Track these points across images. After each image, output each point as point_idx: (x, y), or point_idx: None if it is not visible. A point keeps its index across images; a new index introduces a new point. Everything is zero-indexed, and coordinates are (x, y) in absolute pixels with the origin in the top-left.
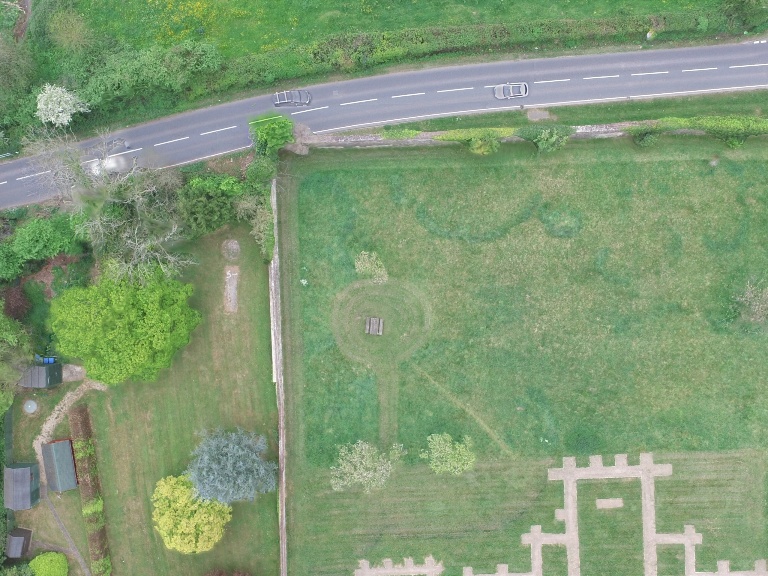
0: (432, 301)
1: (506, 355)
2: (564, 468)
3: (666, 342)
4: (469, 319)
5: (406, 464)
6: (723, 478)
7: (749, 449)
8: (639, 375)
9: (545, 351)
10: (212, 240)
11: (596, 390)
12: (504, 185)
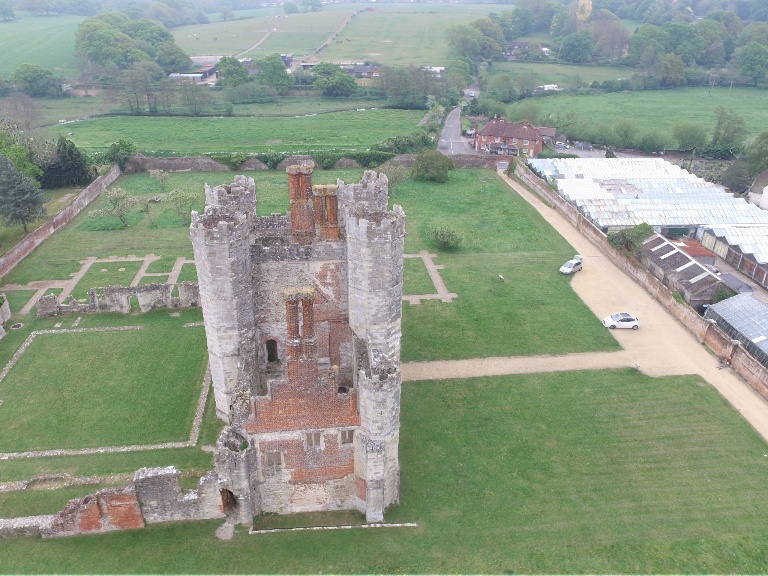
0: None
1: None
2: None
3: None
4: None
5: None
6: None
7: None
8: None
9: None
10: (66, 189)
11: None
12: None
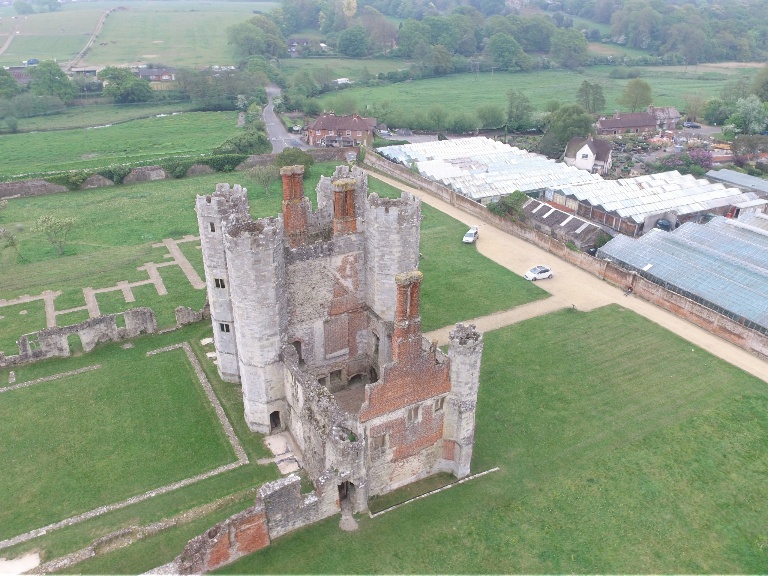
0: None
1: None
2: (165, 242)
3: None
4: None
5: (24, 264)
6: None
7: None
8: None
9: None
10: None
11: None
12: (98, 194)
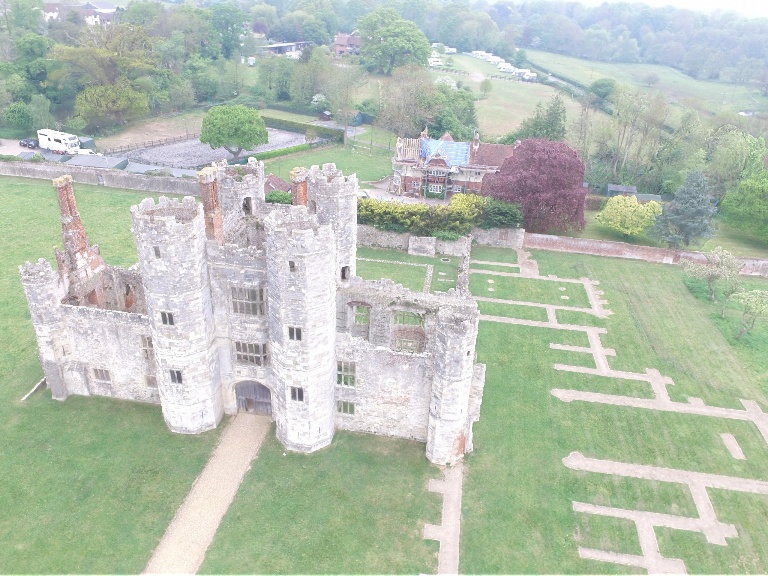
0: None
1: None
2: (764, 414)
3: None
4: None
5: (708, 315)
6: None
7: None
8: None
9: None
10: None
11: None
12: None
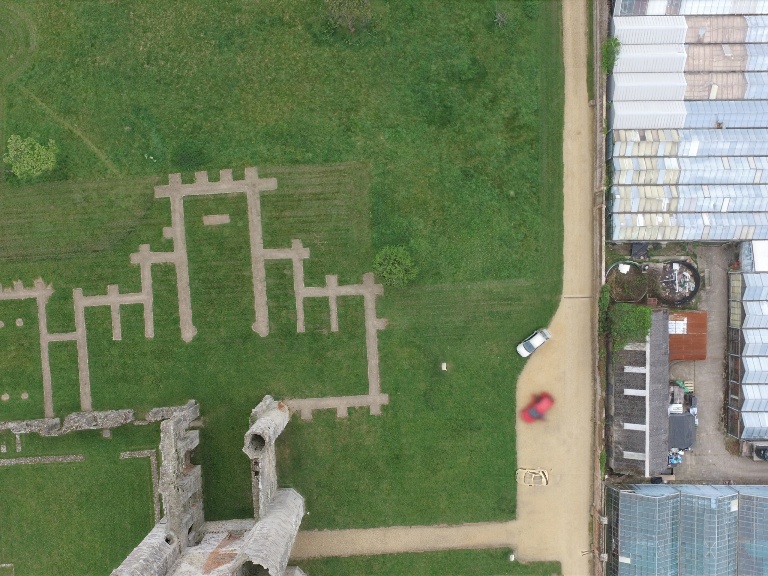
0: (37, 21)
1: (112, 74)
2: (170, 185)
3: (270, 56)
4: (74, 38)
5: (13, 186)
6: (328, 191)
7: (353, 162)
8: (244, 90)
9: (151, 69)
10: None
11: (202, 107)
12: None
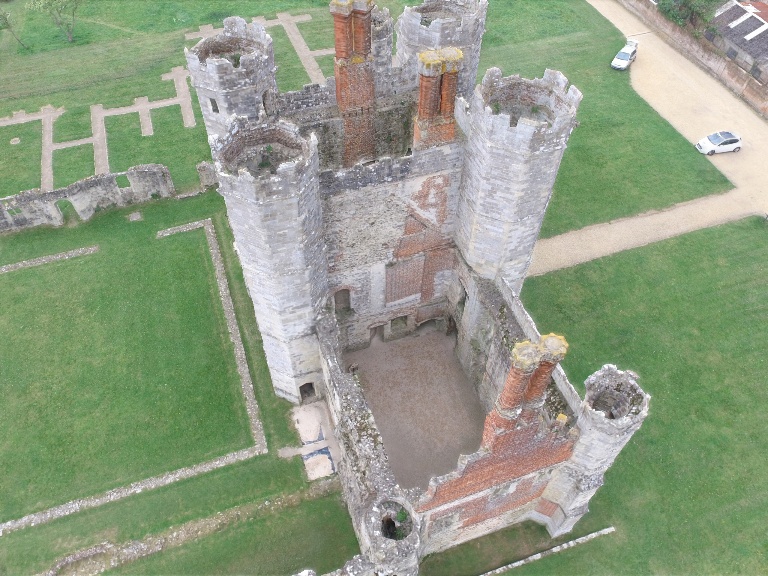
0: None
1: None
2: (201, 31)
3: None
4: None
5: (25, 55)
6: None
7: None
8: None
9: None
10: None
11: None
12: None
